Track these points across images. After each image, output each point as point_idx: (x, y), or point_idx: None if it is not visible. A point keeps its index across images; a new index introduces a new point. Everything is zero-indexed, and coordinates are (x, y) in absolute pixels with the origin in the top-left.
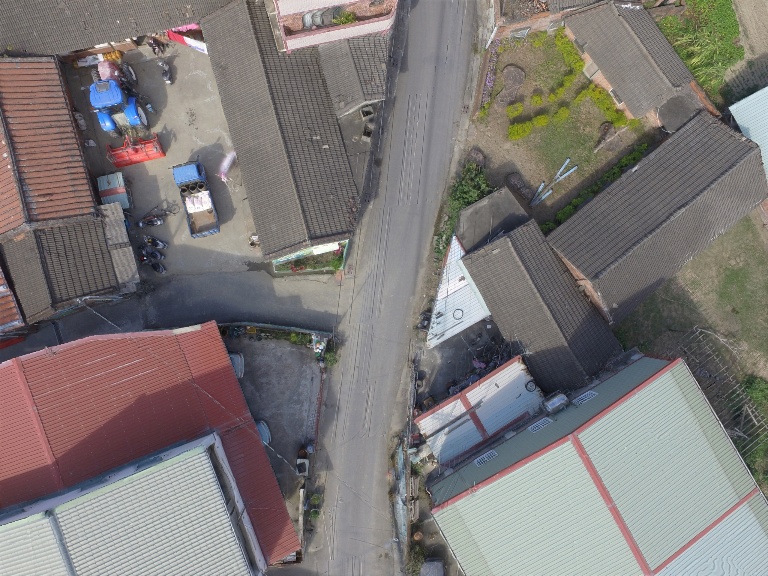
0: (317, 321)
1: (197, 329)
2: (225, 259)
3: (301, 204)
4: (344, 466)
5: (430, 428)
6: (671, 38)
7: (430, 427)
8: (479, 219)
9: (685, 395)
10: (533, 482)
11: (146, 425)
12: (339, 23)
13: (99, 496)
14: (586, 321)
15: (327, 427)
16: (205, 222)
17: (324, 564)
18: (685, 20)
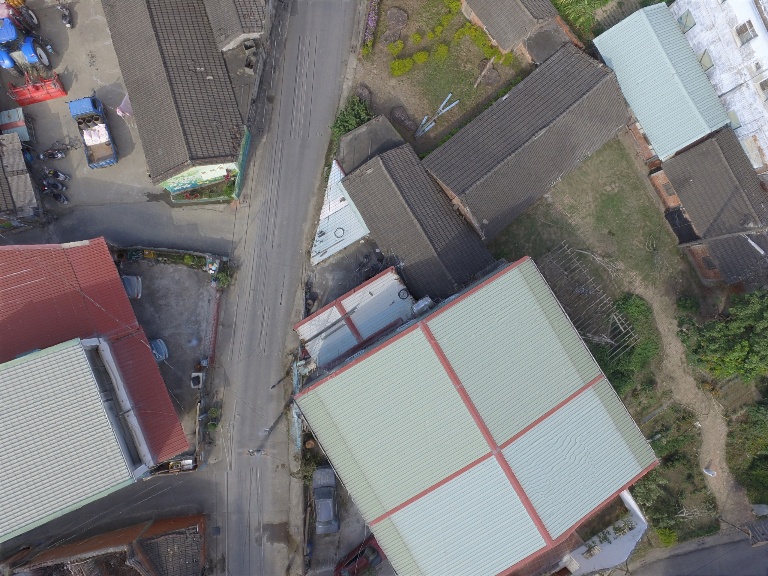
0: (213, 247)
1: (85, 244)
2: (125, 191)
3: (183, 127)
4: (241, 383)
5: (308, 334)
6: None
7: (308, 333)
8: (358, 145)
9: (532, 289)
10: (386, 367)
11: (33, 329)
12: None
13: None
14: (459, 236)
15: (224, 346)
16: (103, 154)
17: (223, 475)
18: None
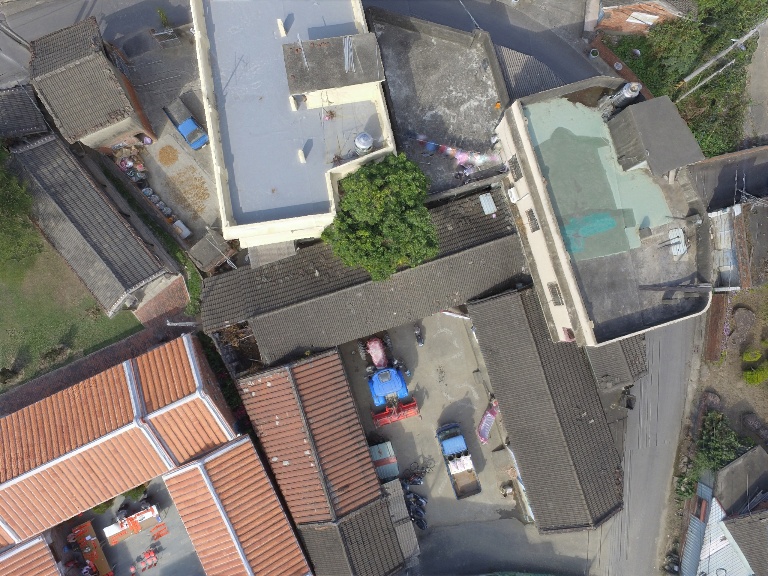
0: (569, 566)
1: None
2: (478, 509)
3: (583, 489)
4: None
5: None
6: None
7: None
8: (736, 478)
9: None
10: None
11: None
12: None
13: None
14: None
15: None
16: (466, 482)
17: None
18: None
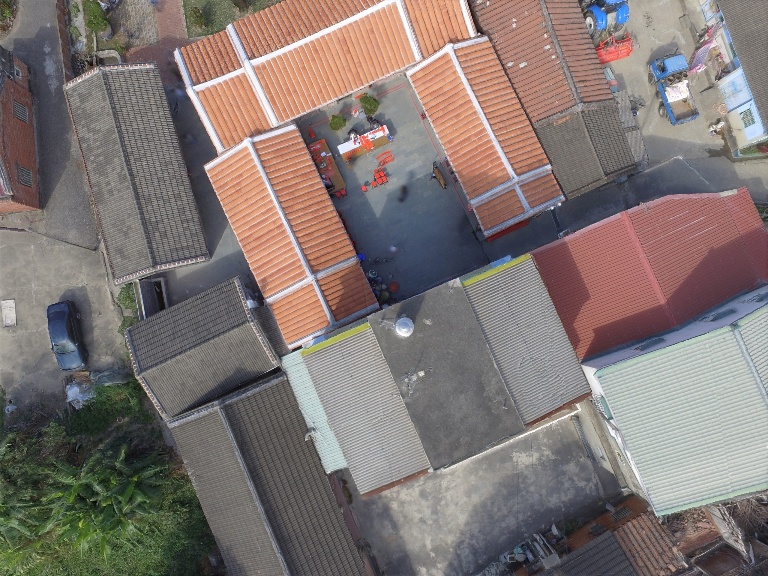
0: None
1: (735, 193)
2: (688, 147)
3: None
4: None
5: None
6: None
7: None
8: None
9: None
10: None
11: (718, 274)
12: None
13: (759, 316)
14: None
15: None
16: (681, 110)
17: None
18: None
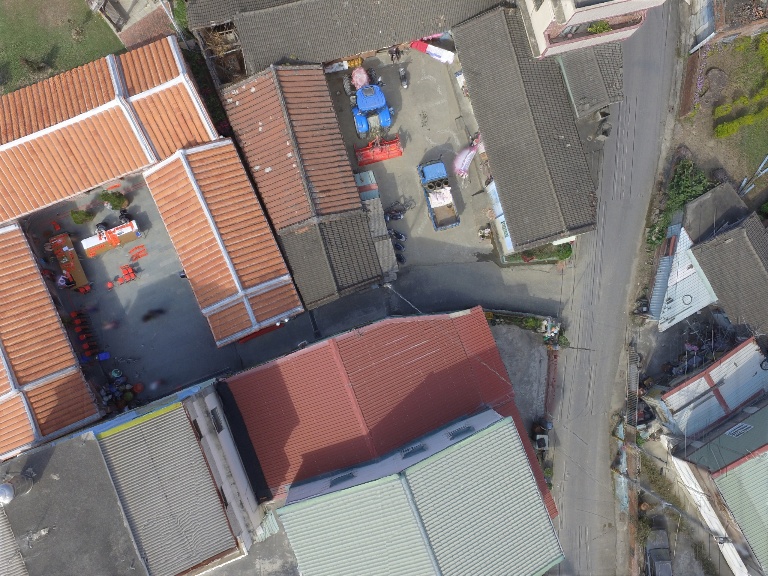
0: (542, 308)
1: (467, 313)
2: (457, 251)
3: (558, 198)
4: (570, 442)
5: (677, 404)
6: None
7: (677, 403)
8: (704, 211)
9: None
10: None
11: (435, 400)
12: (595, 32)
13: (435, 461)
14: None
15: (554, 406)
16: (445, 216)
17: None
18: None
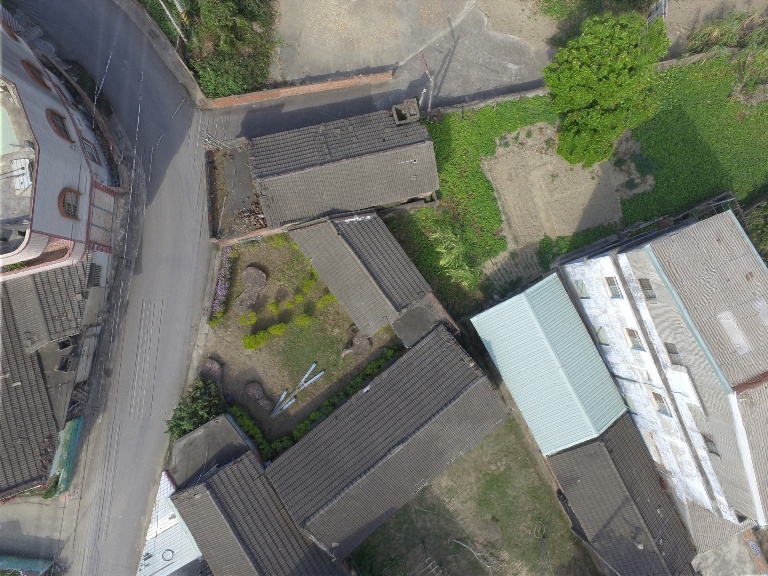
0: (37, 548)
1: None
2: None
3: None
4: None
5: None
6: (427, 231)
7: None
8: (193, 451)
9: None
10: None
11: None
12: (8, 268)
13: None
14: (305, 560)
15: None
16: None
17: None
18: (442, 211)
